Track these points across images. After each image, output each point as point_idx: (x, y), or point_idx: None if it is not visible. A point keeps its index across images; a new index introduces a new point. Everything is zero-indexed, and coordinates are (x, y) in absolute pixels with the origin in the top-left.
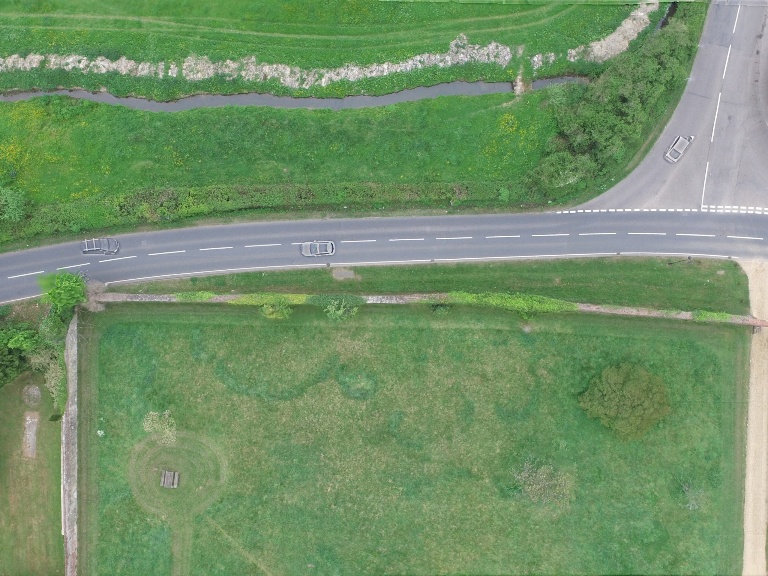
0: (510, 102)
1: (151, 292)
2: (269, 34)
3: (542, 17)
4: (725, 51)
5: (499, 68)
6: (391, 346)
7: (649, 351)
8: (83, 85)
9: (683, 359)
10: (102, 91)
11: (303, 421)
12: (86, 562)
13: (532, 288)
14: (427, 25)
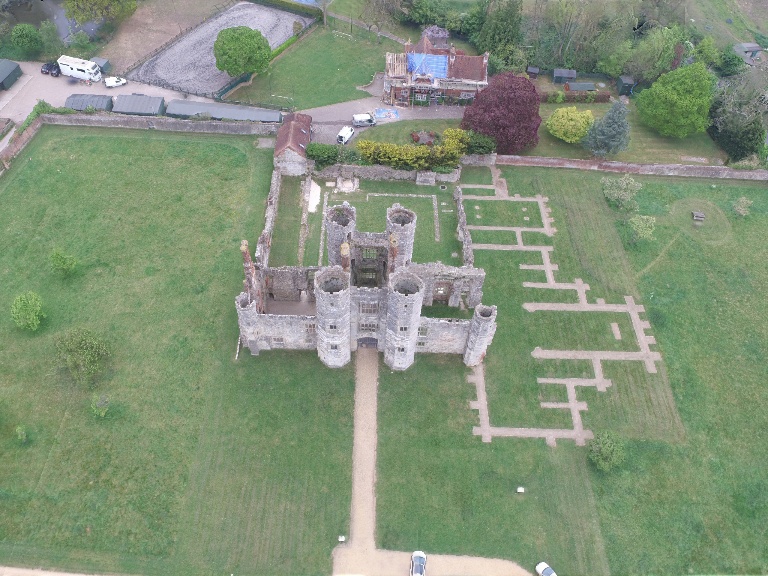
0: None
1: None
2: None
3: None
4: None
5: None
6: None
7: None
8: None
9: None
10: None
11: (767, 285)
12: None
13: None
14: None
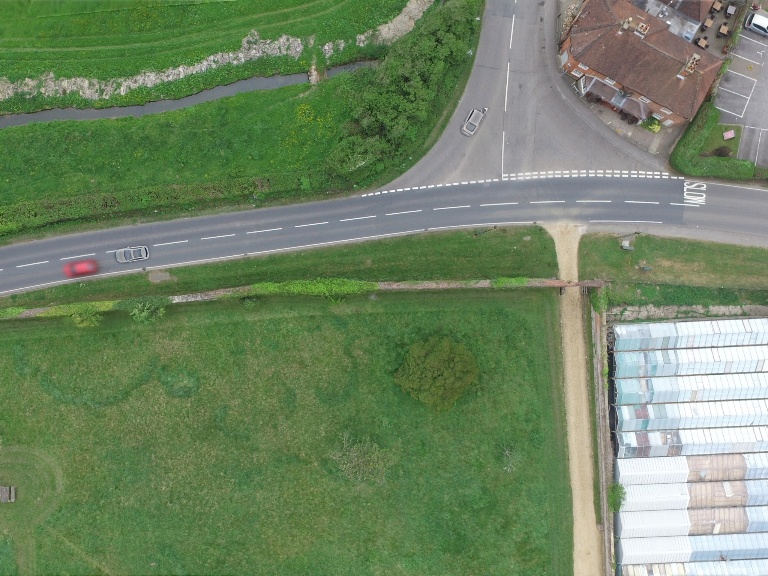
0: (307, 92)
1: None
2: (65, 49)
3: (329, 6)
4: (509, 21)
5: (292, 60)
6: (209, 342)
7: (460, 322)
8: None
9: (494, 326)
10: None
11: (131, 424)
12: None
13: (345, 272)
14: (218, 25)
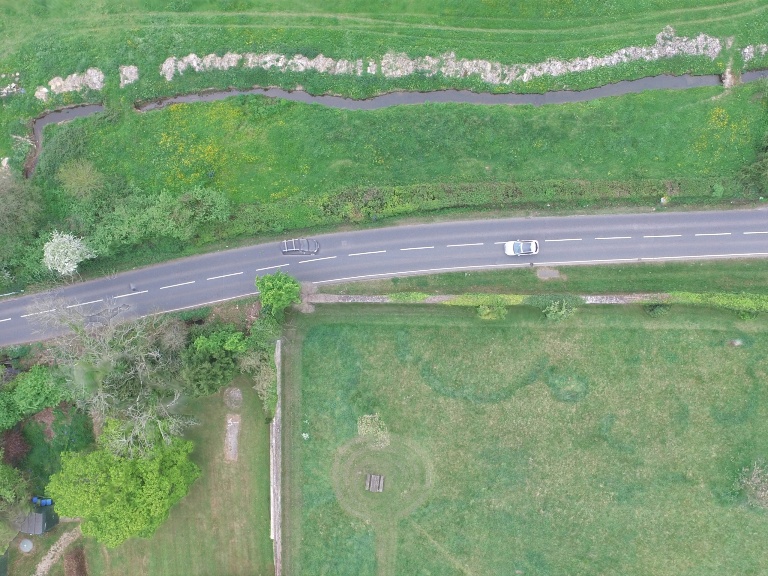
0: (719, 95)
1: (353, 293)
2: (468, 29)
3: (752, 7)
4: None
5: (708, 60)
6: (602, 347)
7: None
8: (280, 84)
9: None
10: (298, 90)
11: (511, 424)
12: (290, 566)
13: (744, 287)
14: (632, 17)
